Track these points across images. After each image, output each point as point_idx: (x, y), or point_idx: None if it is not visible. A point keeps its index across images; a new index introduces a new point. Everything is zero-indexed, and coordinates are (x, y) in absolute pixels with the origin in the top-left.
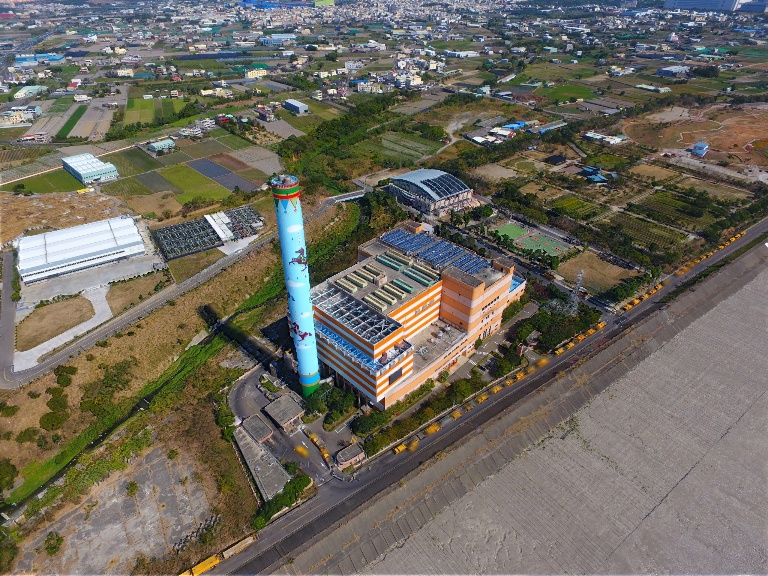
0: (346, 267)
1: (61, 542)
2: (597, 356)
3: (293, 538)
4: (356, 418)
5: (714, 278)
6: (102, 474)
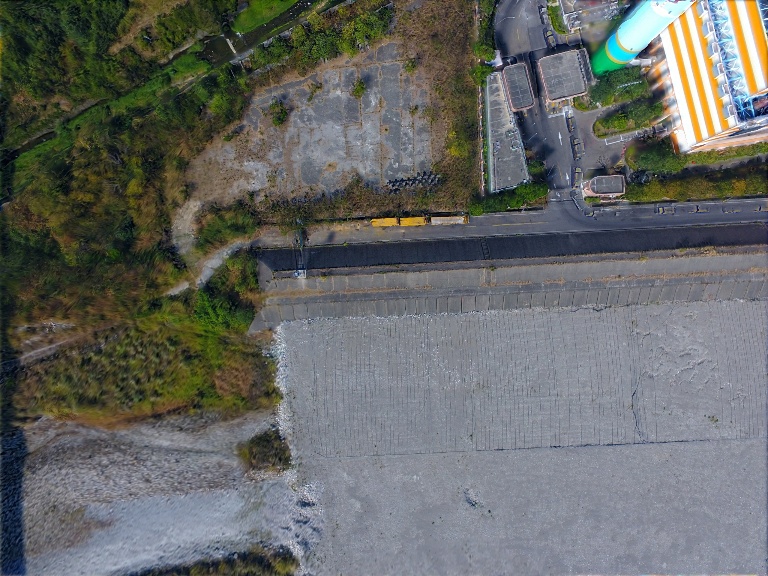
0: None
1: (285, 114)
2: None
3: (502, 243)
4: (640, 137)
5: None
6: (330, 52)
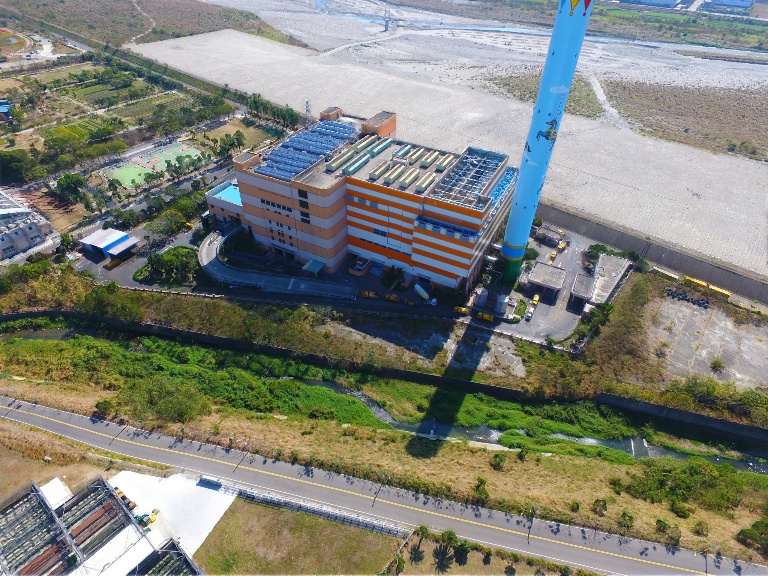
0: (231, 307)
1: None
2: None
3: (631, 248)
4: None
5: None
6: None
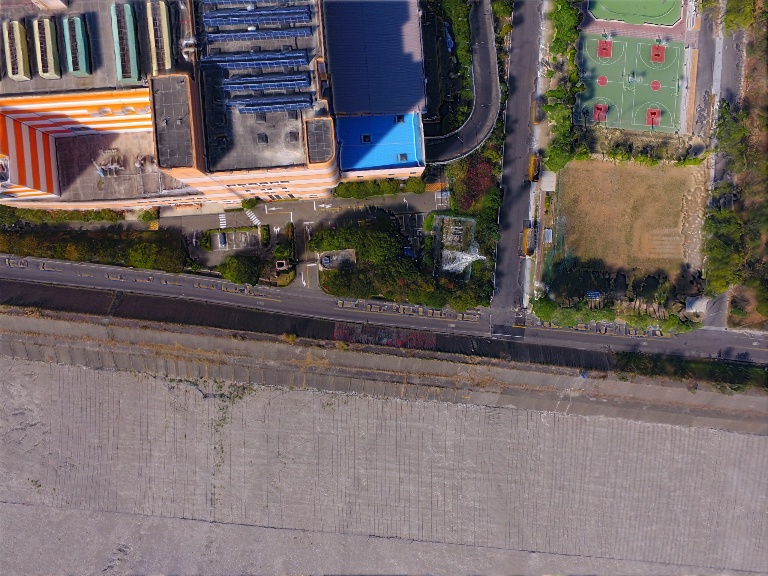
0: None
1: None
2: (375, 356)
3: None
4: None
5: None
6: None
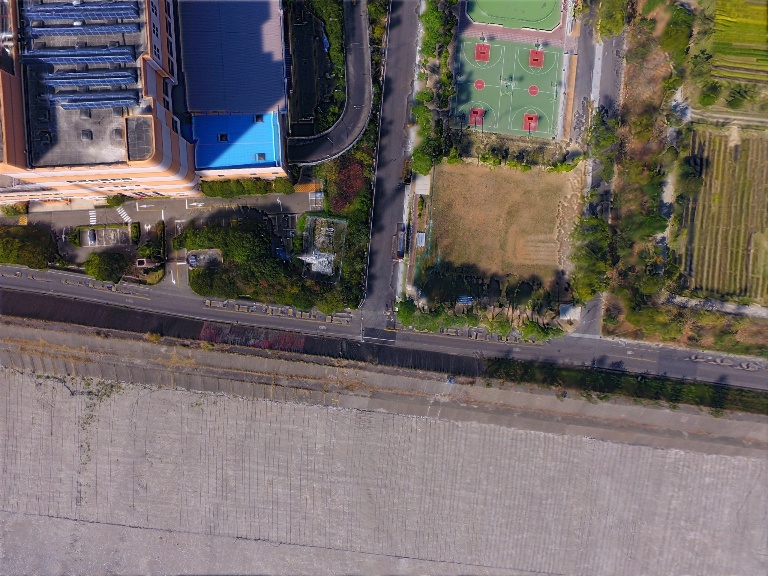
0: None
1: None
2: (240, 356)
3: None
4: None
5: (641, 408)
6: None
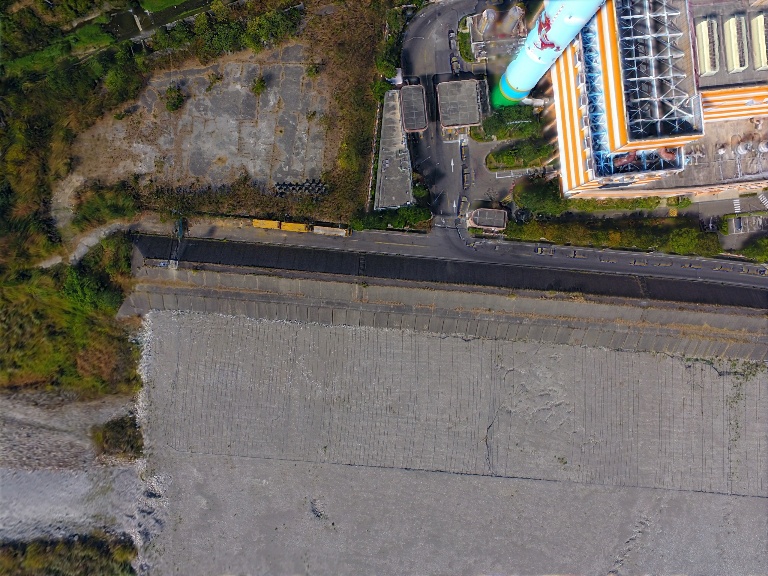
0: None
1: (181, 101)
2: None
3: (380, 261)
4: (530, 175)
5: None
6: (233, 44)
